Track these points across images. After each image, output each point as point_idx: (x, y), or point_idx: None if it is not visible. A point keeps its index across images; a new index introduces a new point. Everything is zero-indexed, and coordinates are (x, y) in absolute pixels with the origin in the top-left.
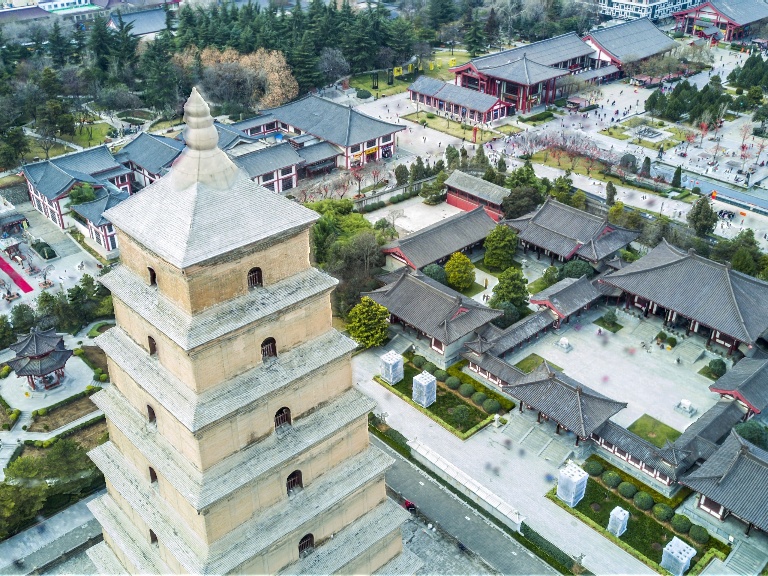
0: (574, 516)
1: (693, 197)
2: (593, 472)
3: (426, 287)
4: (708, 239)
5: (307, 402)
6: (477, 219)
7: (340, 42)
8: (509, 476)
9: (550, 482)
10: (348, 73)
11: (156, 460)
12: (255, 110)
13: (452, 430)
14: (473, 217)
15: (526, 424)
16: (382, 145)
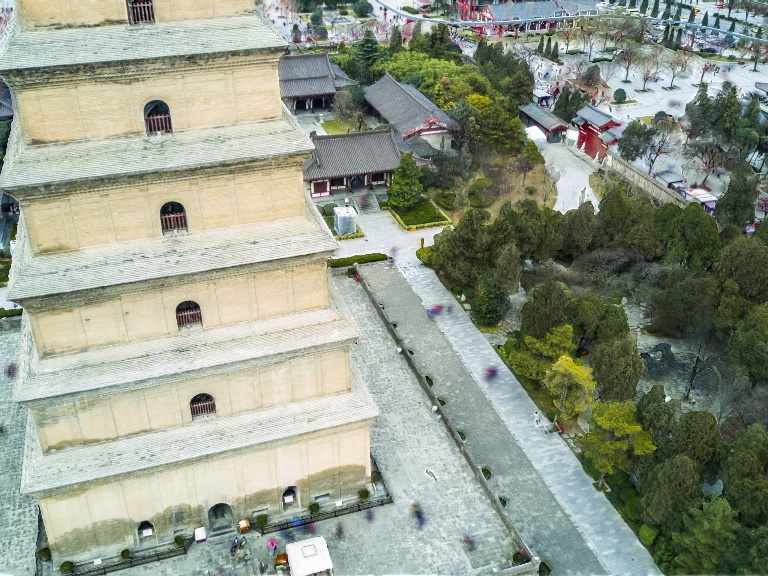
0: None
1: None
2: None
3: None
4: None
5: None
6: None
7: None
8: None
9: None
10: None
11: (209, 154)
12: None
13: None
14: None
15: None
16: None
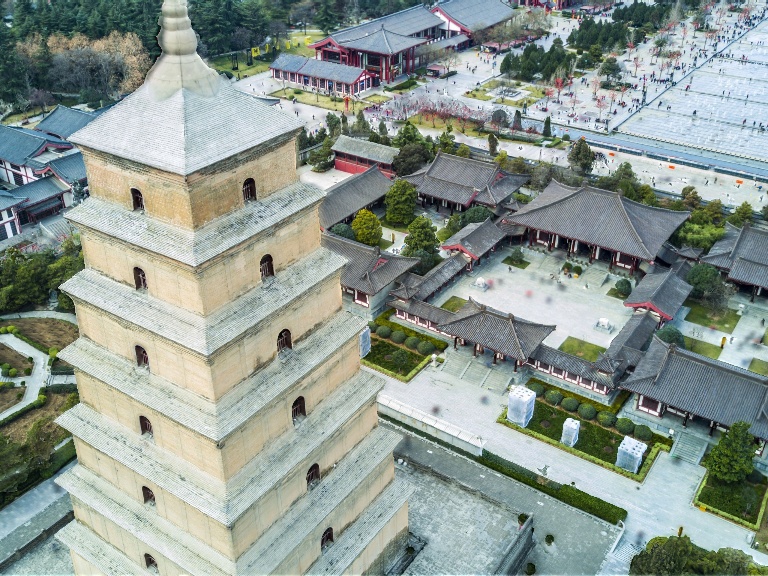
0: (527, 435)
1: (564, 144)
2: (536, 393)
3: (341, 243)
4: (589, 177)
5: (304, 324)
6: (373, 178)
7: (193, 24)
8: (458, 409)
9: (498, 409)
10: (205, 56)
11: (155, 402)
12: (113, 98)
13: (393, 375)
14: (369, 176)
15: (463, 360)
16: None
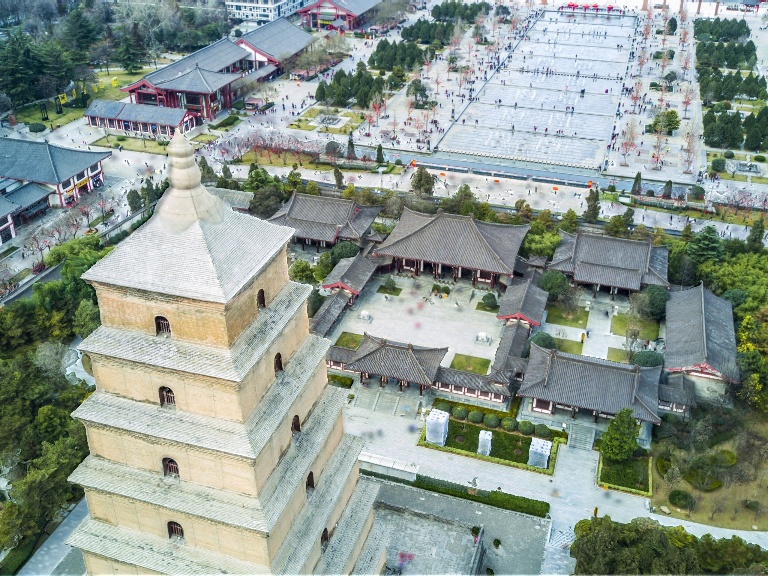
0: (448, 452)
1: (398, 168)
2: None
3: None
4: (433, 200)
5: (307, 406)
6: None
7: None
8: (380, 440)
9: (414, 433)
10: None
11: (194, 507)
12: None
13: None
14: None
15: (372, 392)
16: (91, 175)
